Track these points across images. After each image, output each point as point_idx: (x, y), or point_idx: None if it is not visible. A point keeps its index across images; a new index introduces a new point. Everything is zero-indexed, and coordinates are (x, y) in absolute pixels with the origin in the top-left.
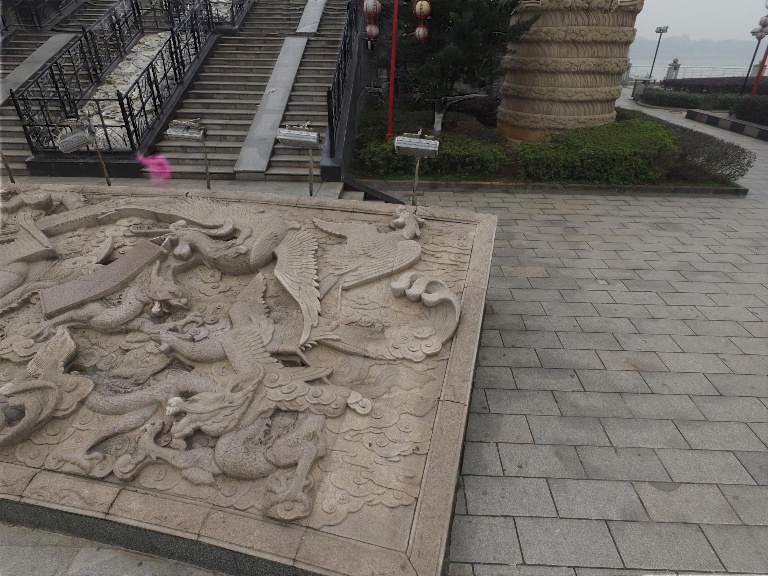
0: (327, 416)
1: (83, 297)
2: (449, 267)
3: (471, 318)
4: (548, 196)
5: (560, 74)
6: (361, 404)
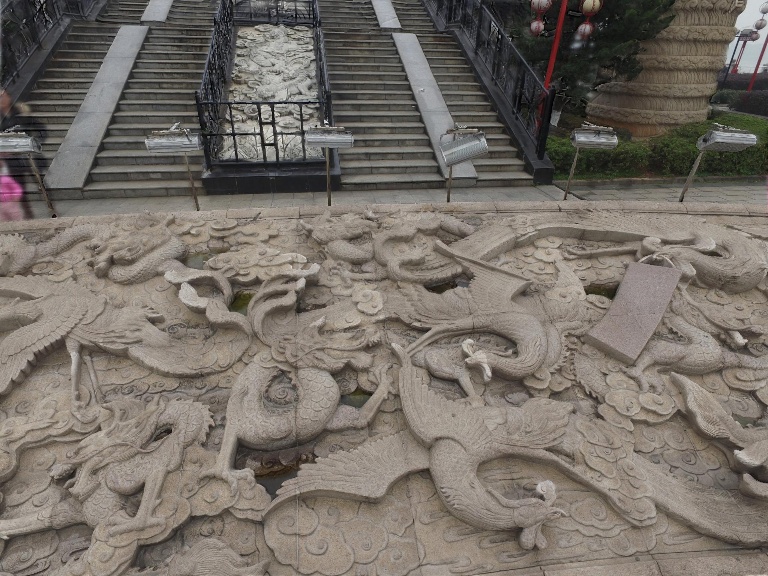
0: None
1: (645, 335)
2: None
3: None
4: (702, 189)
5: (677, 71)
6: None
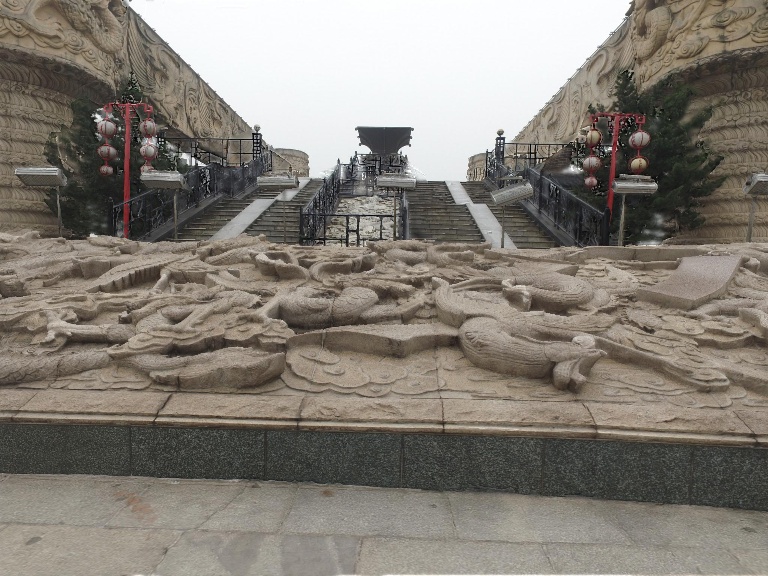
0: None
1: (705, 292)
2: None
3: None
4: None
5: (744, 226)
6: None
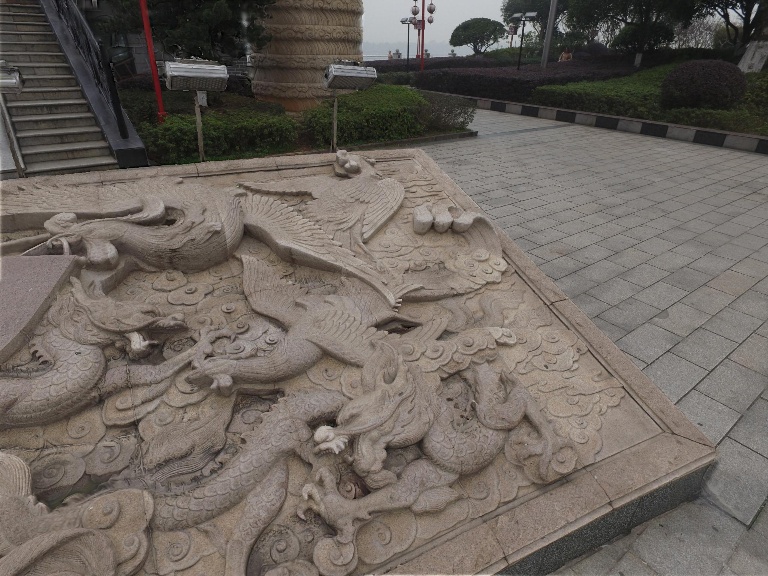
0: (488, 362)
1: None
2: (431, 198)
3: (499, 232)
4: None
5: (316, 42)
6: (507, 334)
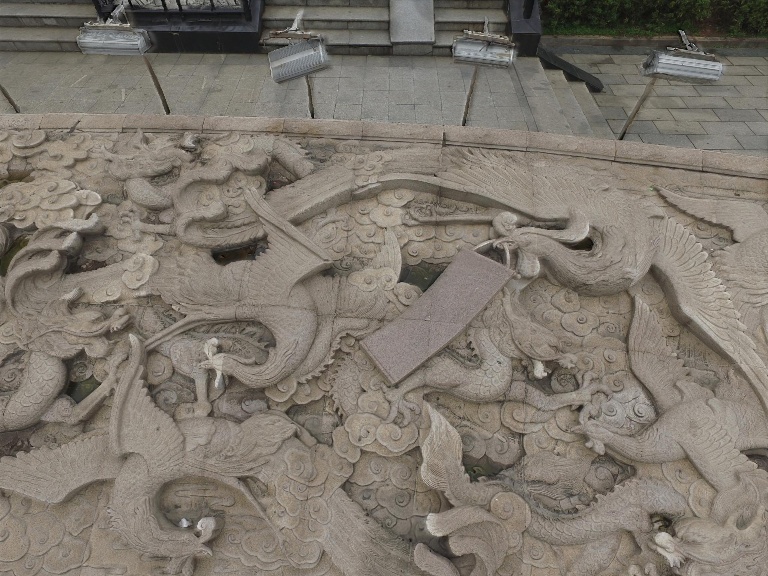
0: None
1: (427, 352)
2: None
3: None
4: None
5: None
6: None
